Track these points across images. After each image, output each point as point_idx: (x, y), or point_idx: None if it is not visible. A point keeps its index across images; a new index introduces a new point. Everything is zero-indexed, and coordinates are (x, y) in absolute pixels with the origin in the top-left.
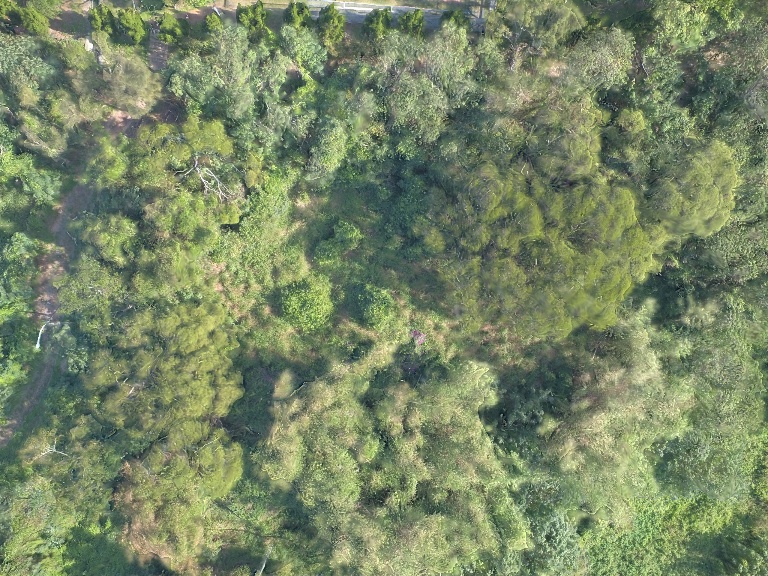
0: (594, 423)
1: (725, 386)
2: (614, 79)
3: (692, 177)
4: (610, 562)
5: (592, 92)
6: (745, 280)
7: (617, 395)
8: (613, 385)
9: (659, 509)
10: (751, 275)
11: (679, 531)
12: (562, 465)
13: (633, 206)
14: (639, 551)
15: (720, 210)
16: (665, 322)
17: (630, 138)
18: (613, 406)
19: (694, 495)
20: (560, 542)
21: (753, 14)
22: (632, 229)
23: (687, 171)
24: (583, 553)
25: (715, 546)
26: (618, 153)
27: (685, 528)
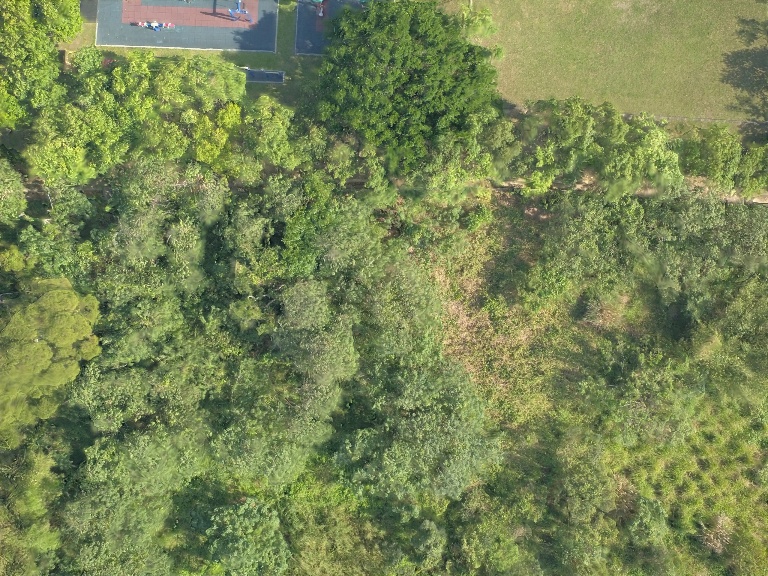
0: None
1: (93, 538)
2: (3, 213)
3: (10, 331)
4: None
5: None
6: None
7: None
8: None
9: None
10: (115, 424)
11: None
12: None
13: None
14: None
15: (56, 362)
16: None
17: (16, 275)
18: None
19: None
20: None
21: (140, 146)
22: None
23: (9, 324)
24: None
25: None
26: (29, 285)
27: None
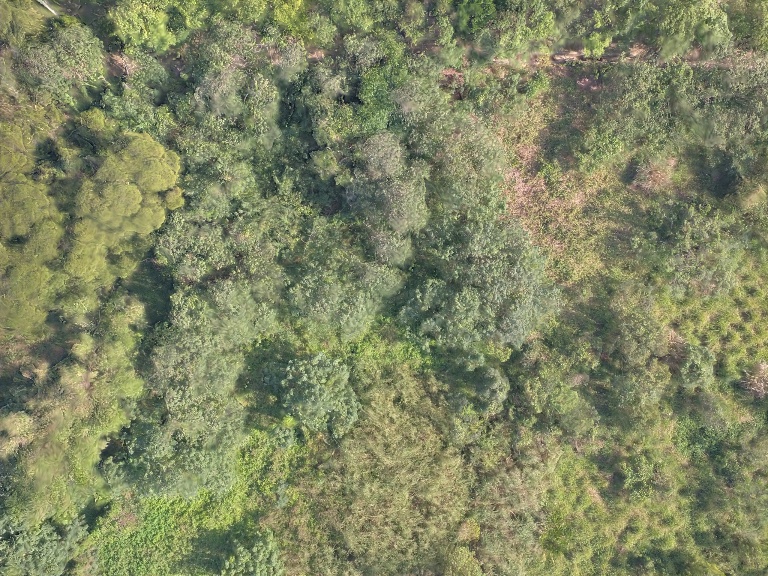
0: (8, 421)
1: (178, 383)
2: (82, 76)
3: (102, 174)
4: (119, 559)
5: (70, 89)
6: (199, 276)
7: (42, 393)
8: (39, 383)
9: (173, 506)
10: (198, 271)
11: (190, 528)
12: (18, 463)
13: (46, 203)
14: (148, 548)
15: (145, 207)
16: (163, 319)
17: (96, 135)
18: (41, 404)
19: (208, 492)
20: (17, 540)
21: (217, 9)
22: (35, 227)
23: (100, 168)
24: (88, 551)
25: (224, 542)
26: (105, 150)
27: (195, 525)
